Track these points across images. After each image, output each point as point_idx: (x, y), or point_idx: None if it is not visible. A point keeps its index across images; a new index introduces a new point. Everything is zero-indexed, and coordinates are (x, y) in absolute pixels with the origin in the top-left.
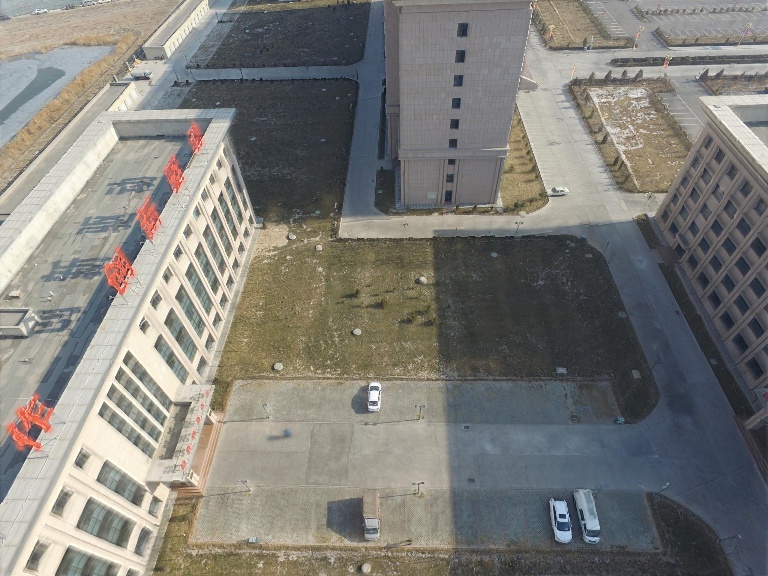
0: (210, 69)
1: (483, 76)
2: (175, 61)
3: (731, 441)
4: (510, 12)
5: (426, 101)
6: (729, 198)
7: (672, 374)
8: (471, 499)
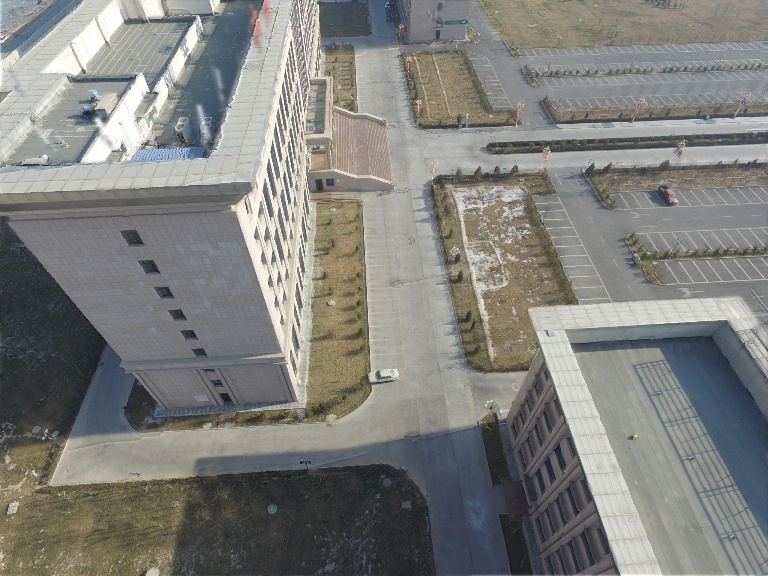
0: None
1: (201, 286)
2: None
3: None
4: (200, 216)
5: (128, 315)
6: None
7: None
8: None
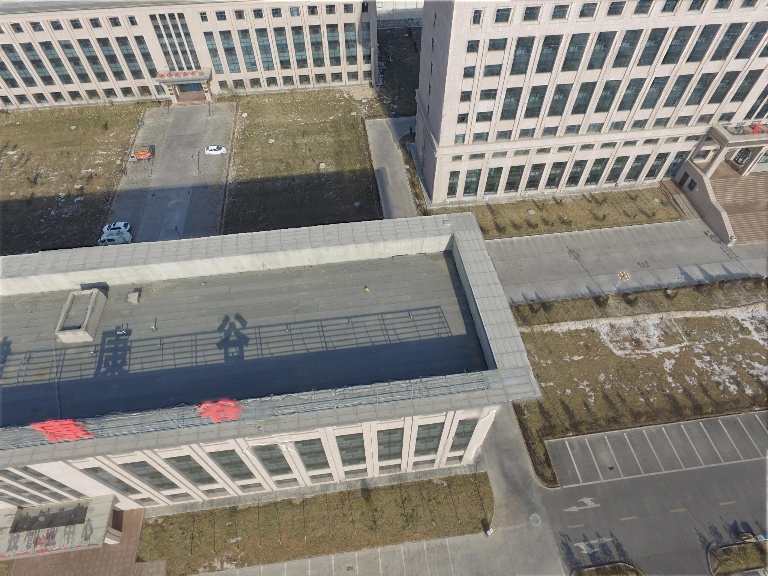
0: None
1: None
2: None
3: None
4: None
5: None
6: None
7: None
8: (142, 195)
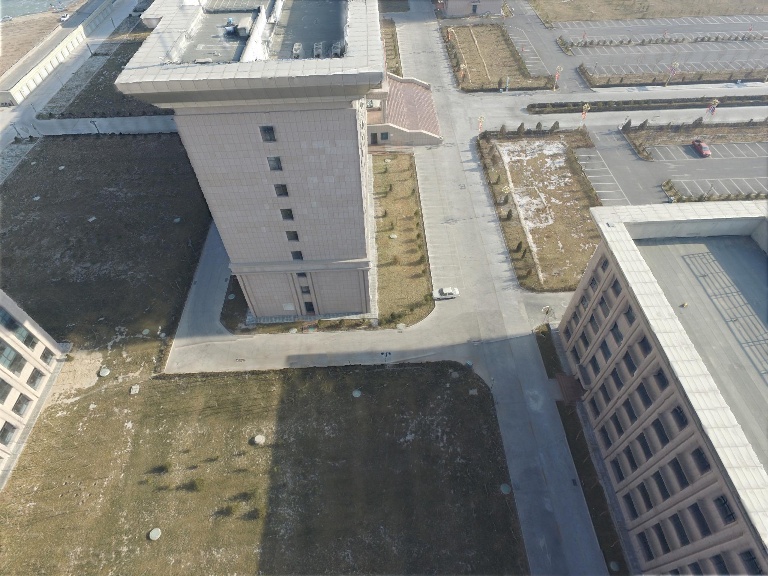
0: (65, 119)
1: (313, 185)
2: (26, 108)
3: None
4: (326, 113)
5: (246, 213)
6: (627, 349)
7: None
8: None
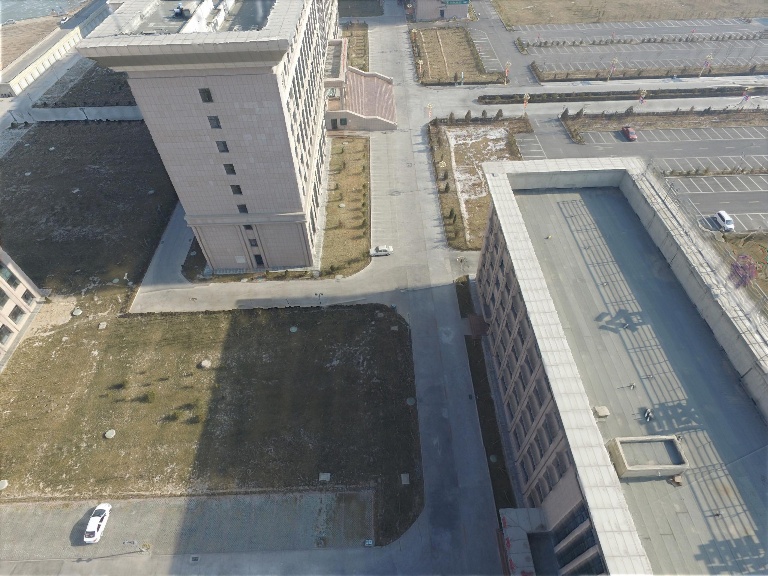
0: (58, 108)
1: (248, 142)
2: (23, 99)
3: (487, 563)
4: (252, 77)
5: (195, 167)
6: None
7: (444, 477)
8: None
